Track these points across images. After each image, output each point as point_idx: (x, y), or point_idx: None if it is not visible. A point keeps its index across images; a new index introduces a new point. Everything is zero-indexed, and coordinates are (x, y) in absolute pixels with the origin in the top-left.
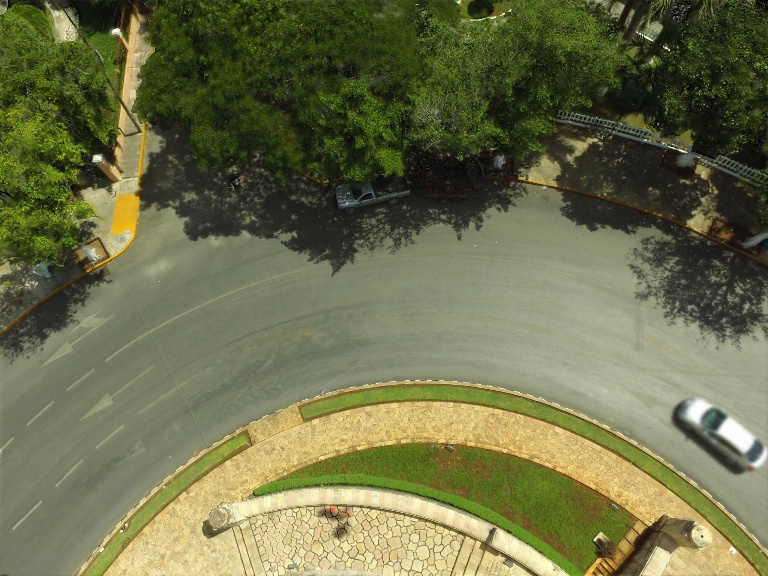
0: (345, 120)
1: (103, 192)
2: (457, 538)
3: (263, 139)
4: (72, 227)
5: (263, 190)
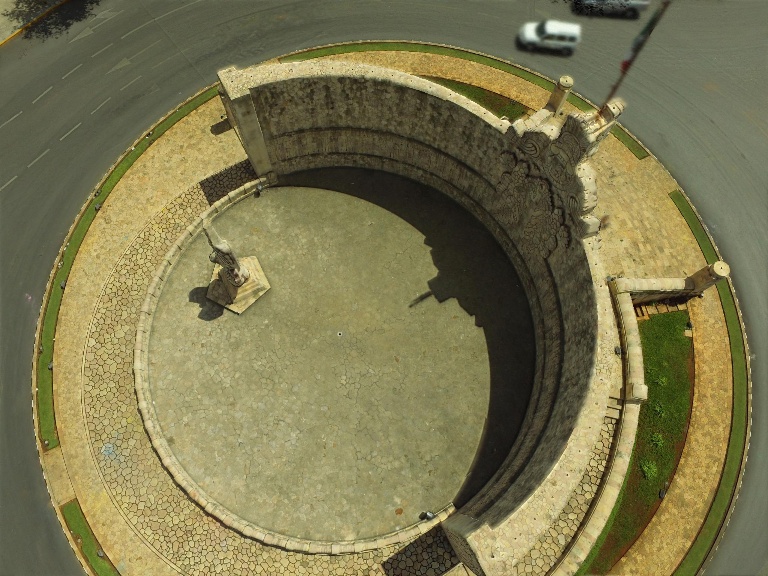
0: None
1: None
2: None
3: None
4: None
5: None
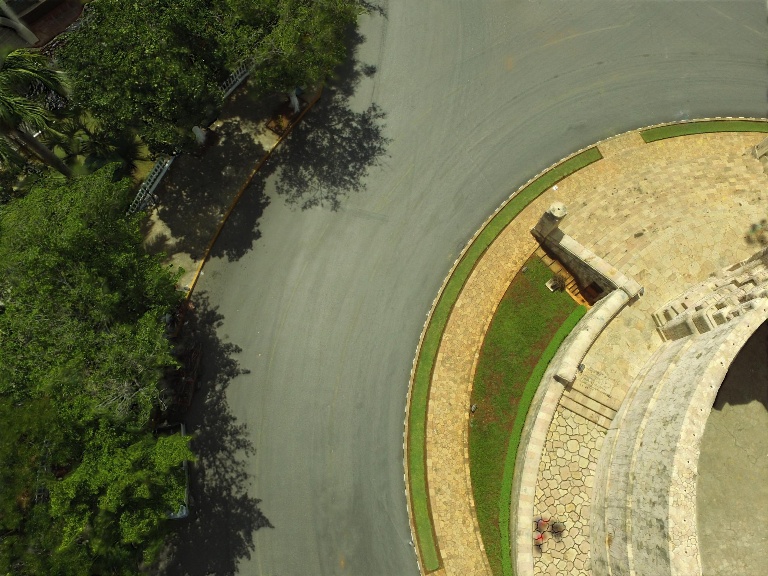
0: (98, 510)
1: None
2: (560, 412)
3: None
4: None
5: None
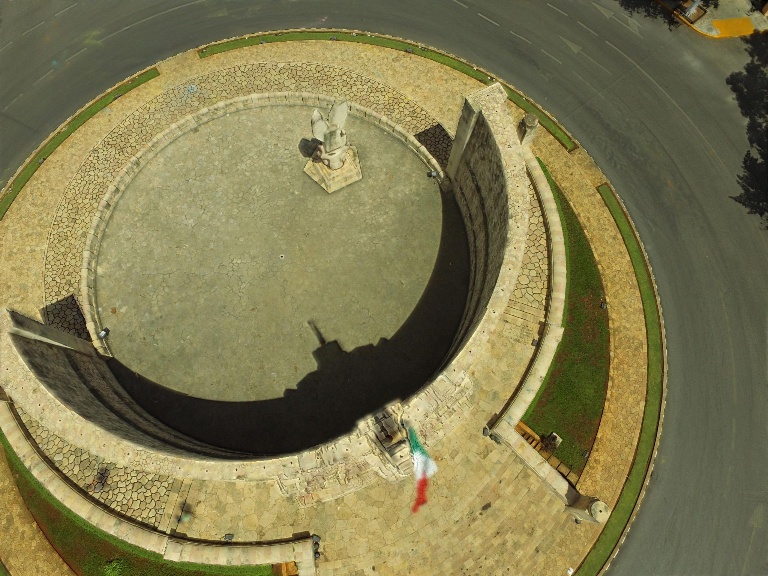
0: None
1: (749, 6)
2: (541, 305)
3: None
4: None
5: None
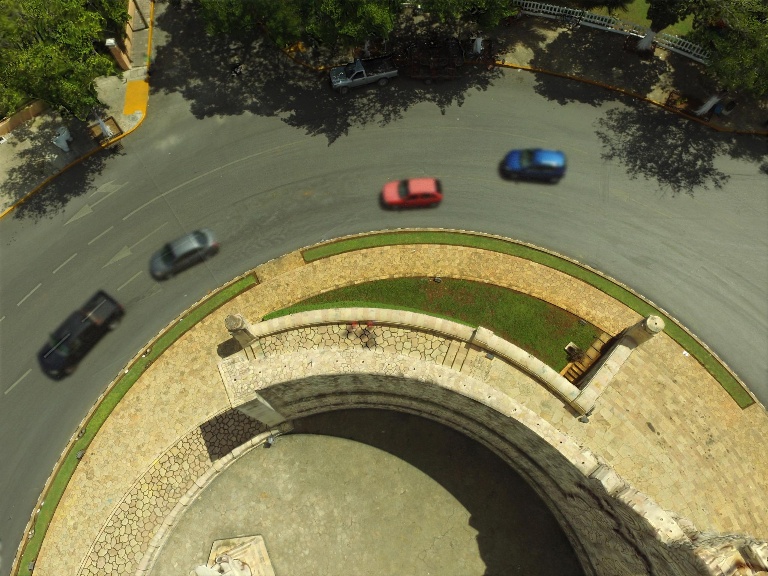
0: None
1: (115, 79)
2: (445, 342)
3: (265, 2)
4: (92, 89)
5: (263, 76)
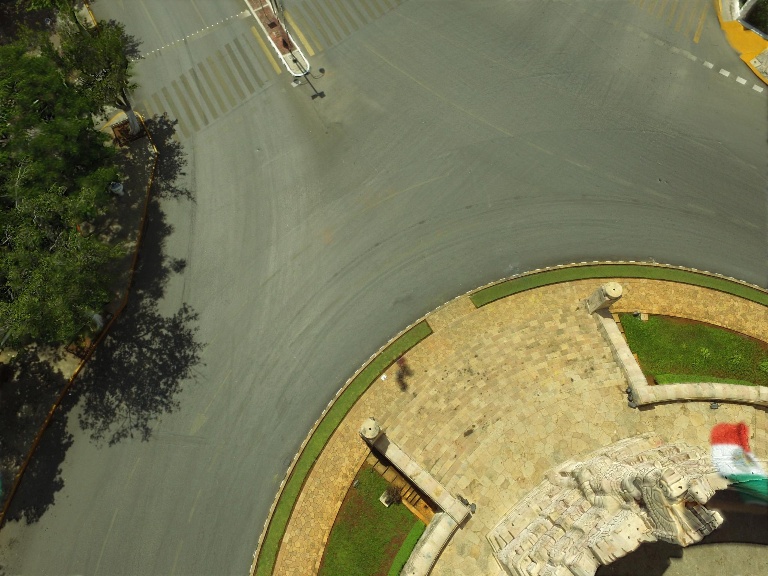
0: None
1: None
2: None
3: None
4: None
5: None
